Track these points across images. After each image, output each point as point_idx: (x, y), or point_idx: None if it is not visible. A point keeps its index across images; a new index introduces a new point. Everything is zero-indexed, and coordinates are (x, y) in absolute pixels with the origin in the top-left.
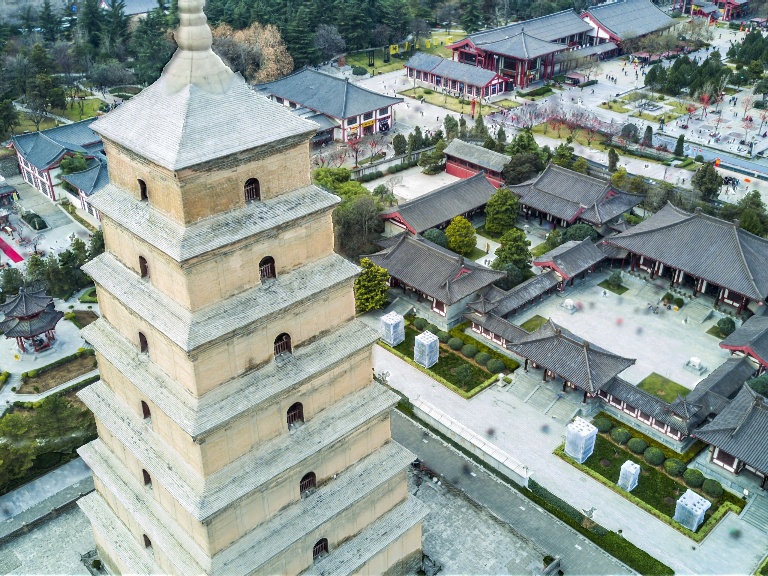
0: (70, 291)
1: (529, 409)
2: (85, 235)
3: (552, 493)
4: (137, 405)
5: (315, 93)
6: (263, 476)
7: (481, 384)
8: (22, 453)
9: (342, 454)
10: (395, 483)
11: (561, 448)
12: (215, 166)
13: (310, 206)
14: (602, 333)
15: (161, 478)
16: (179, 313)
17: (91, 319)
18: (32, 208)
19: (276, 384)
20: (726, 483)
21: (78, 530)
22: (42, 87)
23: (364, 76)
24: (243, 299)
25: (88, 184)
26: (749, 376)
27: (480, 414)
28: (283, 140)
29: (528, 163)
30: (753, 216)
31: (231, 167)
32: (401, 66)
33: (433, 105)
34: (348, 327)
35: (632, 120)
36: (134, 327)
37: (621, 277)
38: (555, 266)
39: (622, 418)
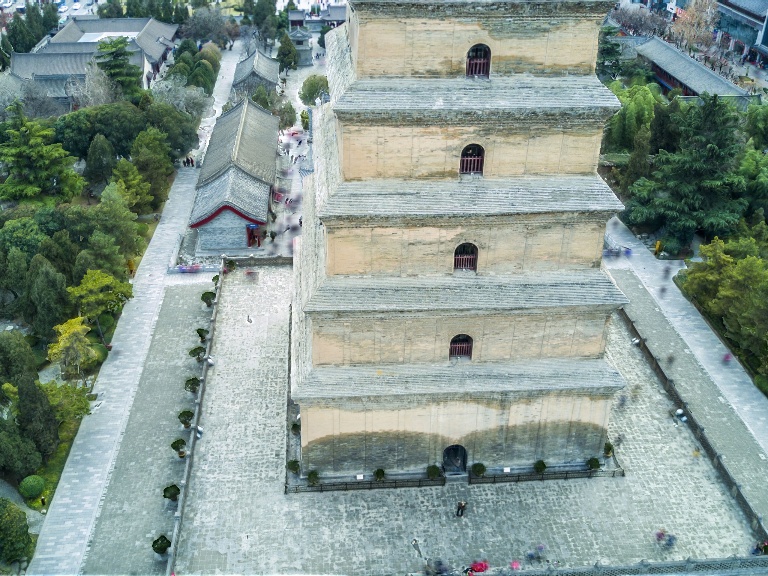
0: None
1: None
2: None
3: None
4: None
5: None
6: None
7: None
8: None
9: None
10: None
11: None
12: None
13: None
14: None
15: None
16: None
17: None
18: None
19: None
20: None
21: None
22: None
23: None
24: None
25: None
26: None
27: None
28: None
29: None
30: None
31: None
32: None
33: None
34: None
35: None
36: None
37: None
38: None
39: None
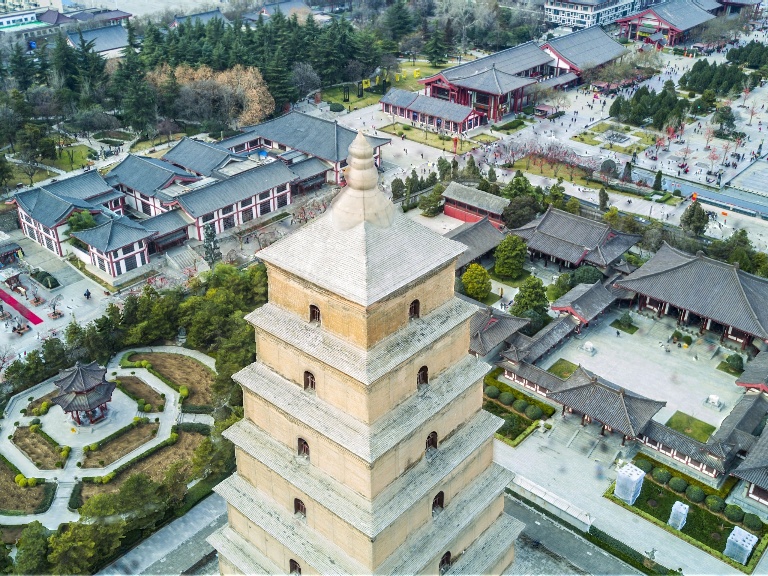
0: (108, 356)
1: (572, 454)
2: (100, 292)
3: (611, 536)
4: (288, 501)
5: (305, 136)
6: (418, 563)
7: (524, 431)
8: (112, 533)
9: (470, 531)
10: (506, 550)
11: (610, 491)
12: (392, 295)
13: (457, 318)
14: (624, 374)
15: (325, 572)
16: (354, 426)
17: (137, 385)
18: (40, 265)
19: (430, 479)
20: (763, 516)
21: None
22: (32, 138)
23: (341, 112)
24: (406, 407)
25: (101, 241)
26: (766, 411)
27: (529, 461)
28: (441, 264)
29: (528, 206)
30: (744, 254)
31: (402, 294)
32: (375, 100)
33: (414, 142)
34: (477, 417)
35: (605, 152)
36: (293, 433)
37: (631, 317)
38: (573, 311)
39: (659, 458)
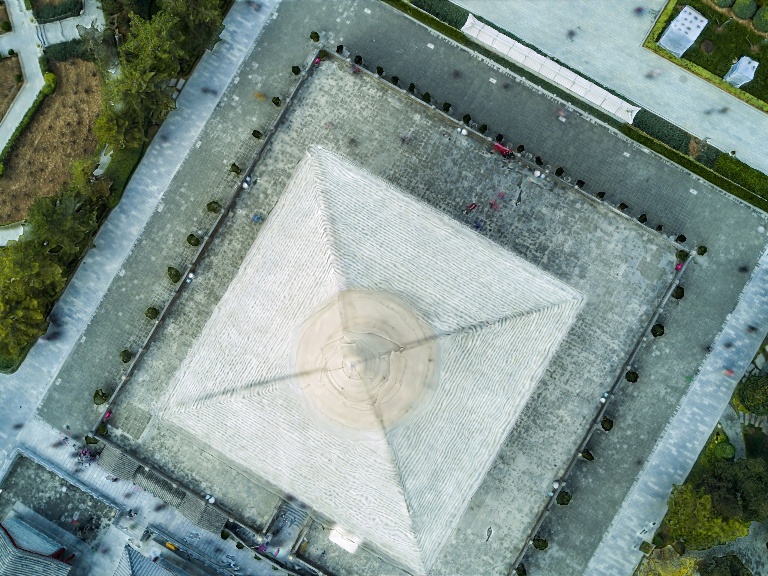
0: None
1: None
2: None
3: (651, 112)
4: None
5: None
6: None
7: None
8: (49, 282)
9: None
10: None
11: (653, 37)
12: None
13: None
14: None
15: None
16: None
17: None
18: None
19: None
20: None
21: (180, 358)
22: None
23: None
24: None
25: None
26: None
27: (543, 2)
28: None
29: None
30: None
31: None
32: None
33: None
34: None
35: None
36: None
37: None
38: None
39: None
